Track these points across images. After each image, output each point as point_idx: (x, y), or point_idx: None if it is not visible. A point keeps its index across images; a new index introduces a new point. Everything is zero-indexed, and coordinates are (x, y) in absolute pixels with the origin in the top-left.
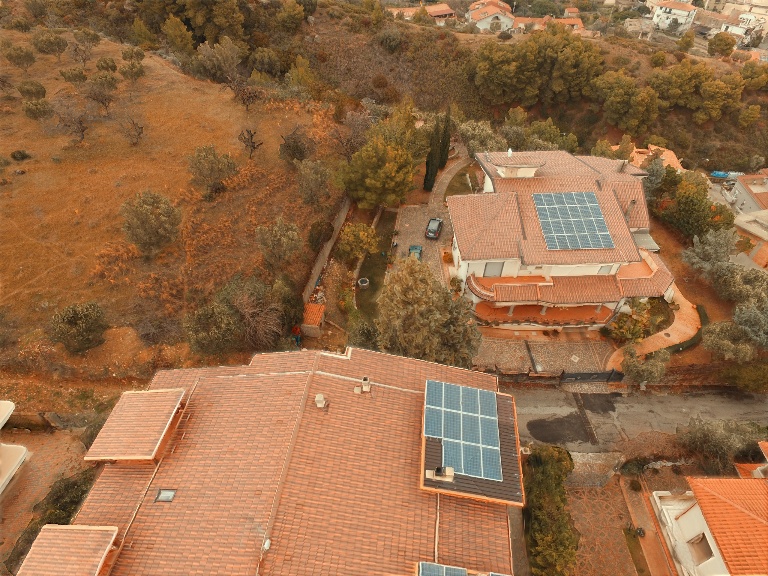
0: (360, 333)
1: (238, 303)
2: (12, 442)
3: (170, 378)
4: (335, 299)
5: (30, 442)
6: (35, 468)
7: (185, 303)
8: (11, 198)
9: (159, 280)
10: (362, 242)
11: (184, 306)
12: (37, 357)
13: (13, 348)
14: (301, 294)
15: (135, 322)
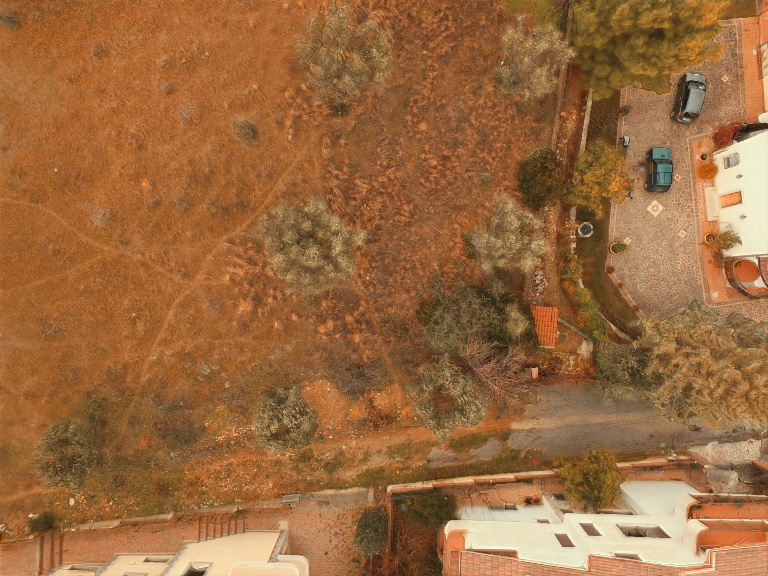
0: (626, 378)
1: (468, 355)
2: (259, 513)
3: (483, 567)
4: (556, 275)
5: (277, 512)
6: (300, 538)
7: (381, 337)
8: (5, 151)
9: (336, 309)
10: (607, 191)
11: (379, 338)
12: (239, 439)
13: (205, 436)
14: (527, 299)
15: (329, 374)
